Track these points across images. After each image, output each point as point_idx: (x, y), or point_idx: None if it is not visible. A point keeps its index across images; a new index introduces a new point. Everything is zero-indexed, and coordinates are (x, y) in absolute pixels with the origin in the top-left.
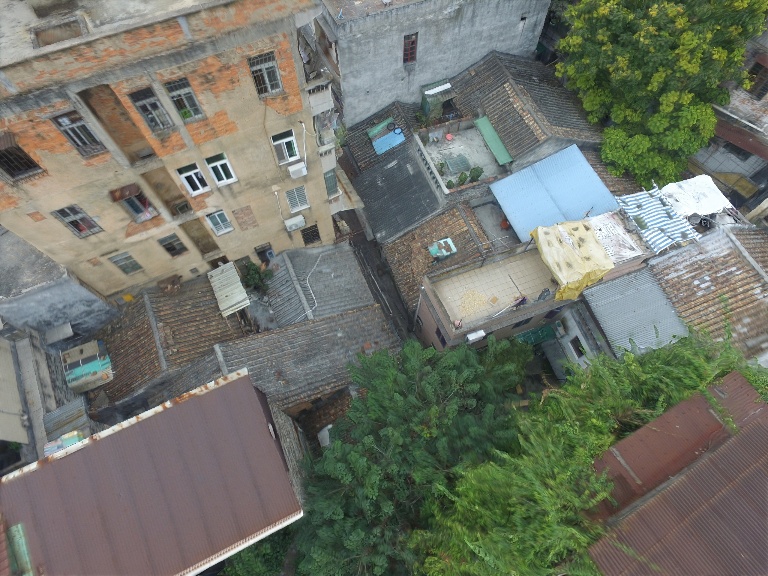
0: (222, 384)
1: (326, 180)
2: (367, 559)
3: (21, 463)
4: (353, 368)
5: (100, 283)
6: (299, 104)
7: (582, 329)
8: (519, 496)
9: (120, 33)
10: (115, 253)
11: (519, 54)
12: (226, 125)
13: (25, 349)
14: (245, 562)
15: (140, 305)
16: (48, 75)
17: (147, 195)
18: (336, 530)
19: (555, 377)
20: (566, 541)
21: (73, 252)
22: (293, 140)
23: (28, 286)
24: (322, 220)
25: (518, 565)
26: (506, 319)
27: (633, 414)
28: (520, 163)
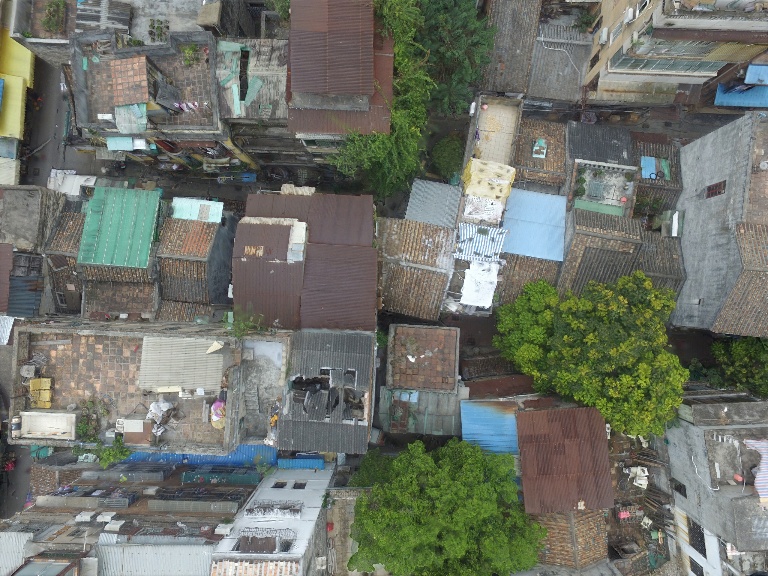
0: None
1: (619, 51)
2: None
3: None
4: None
5: None
6: None
7: None
8: None
9: None
10: None
11: None
12: None
13: None
14: None
15: None
16: None
17: None
18: None
19: None
20: None
21: None
22: None
23: None
24: None
25: None
26: None
27: None
28: None
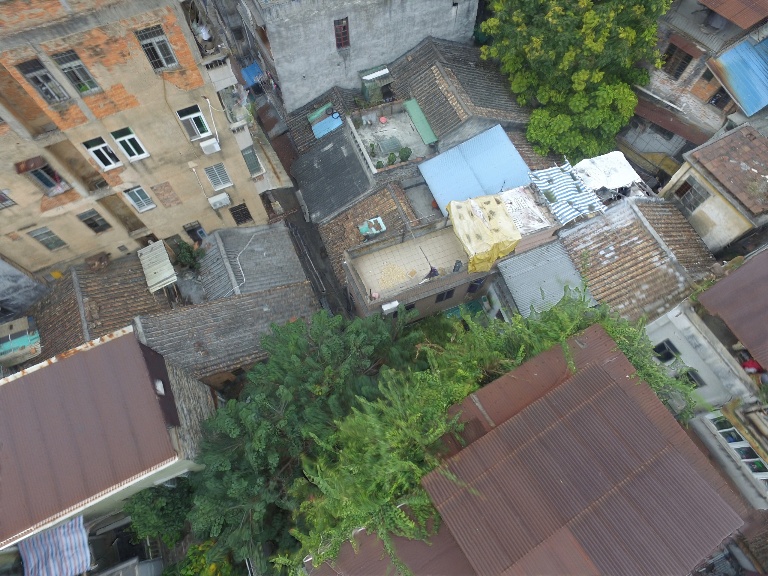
0: (107, 341)
1: (245, 158)
2: (249, 506)
3: None
4: (267, 337)
5: (23, 258)
6: (199, 79)
7: (502, 302)
8: (372, 436)
9: None
10: (33, 228)
11: (456, 40)
12: (125, 99)
13: None
14: (141, 515)
15: (68, 281)
16: None
17: (55, 168)
18: (225, 482)
19: None
20: (410, 475)
21: None
22: (201, 116)
23: None
24: (250, 199)
25: (356, 495)
26: (422, 291)
27: (498, 365)
28: (445, 143)
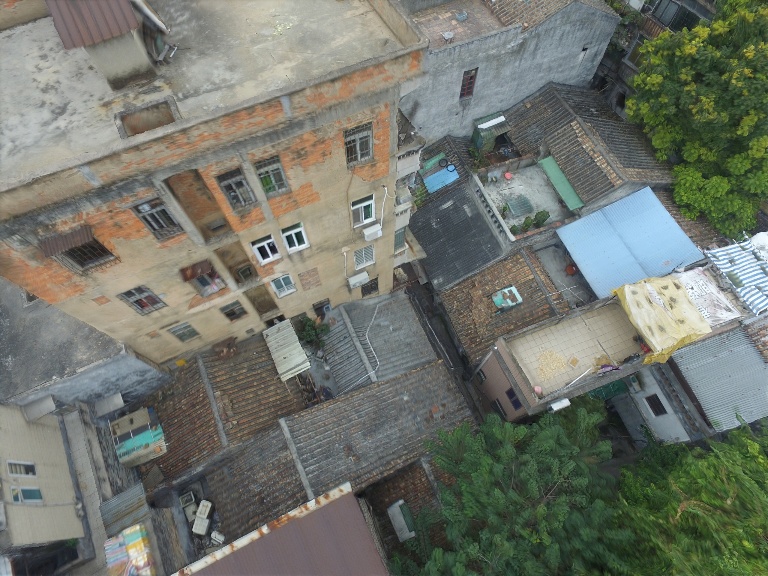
0: (324, 503)
1: (396, 237)
2: None
3: (79, 561)
4: (433, 446)
5: (155, 353)
6: (386, 169)
7: (664, 389)
8: None
9: (218, 118)
10: (175, 324)
11: (575, 84)
12: (309, 196)
13: (74, 424)
14: None
15: (194, 370)
16: (135, 165)
17: (217, 269)
18: None
19: (625, 432)
20: None
21: (133, 328)
22: (372, 203)
23: (83, 364)
24: (384, 273)
25: None
26: (589, 384)
27: None
28: (591, 208)
